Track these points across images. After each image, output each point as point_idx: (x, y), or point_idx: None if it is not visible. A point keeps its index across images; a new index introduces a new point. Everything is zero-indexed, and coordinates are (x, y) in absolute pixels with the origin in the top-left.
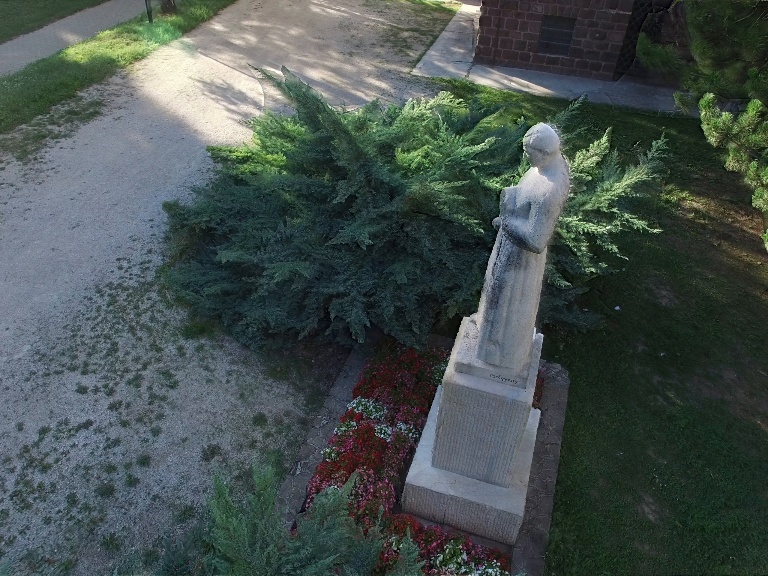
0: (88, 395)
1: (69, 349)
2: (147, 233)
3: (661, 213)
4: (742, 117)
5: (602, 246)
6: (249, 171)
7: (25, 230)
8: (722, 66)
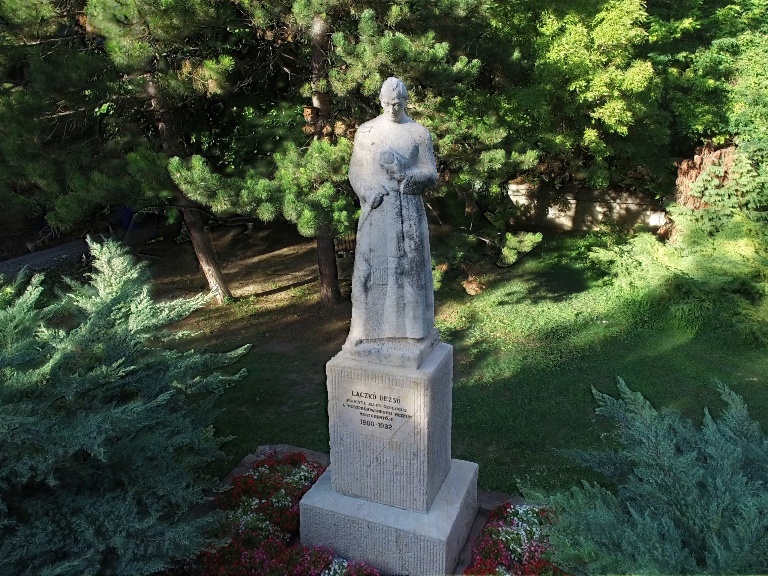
0: None
1: None
2: None
3: None
4: None
5: (174, 339)
6: None
7: None
8: (93, 166)
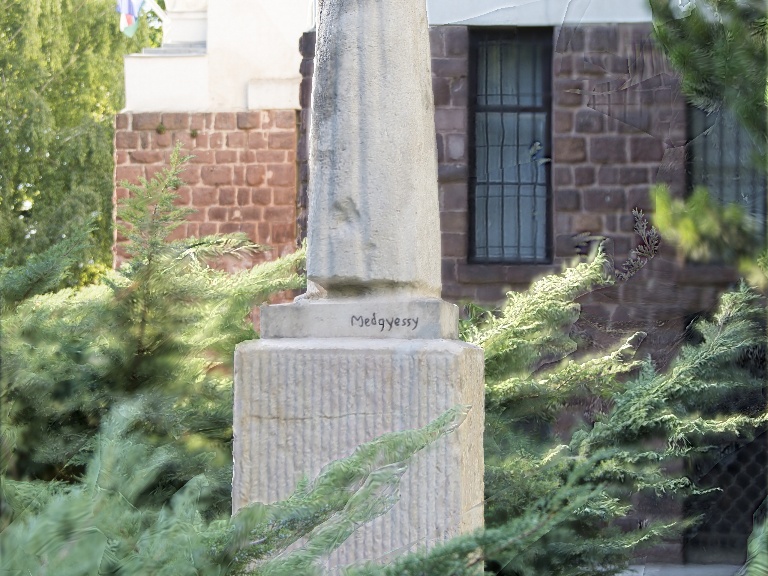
0: None
1: None
2: None
3: None
4: None
5: (650, 486)
6: None
7: None
8: None
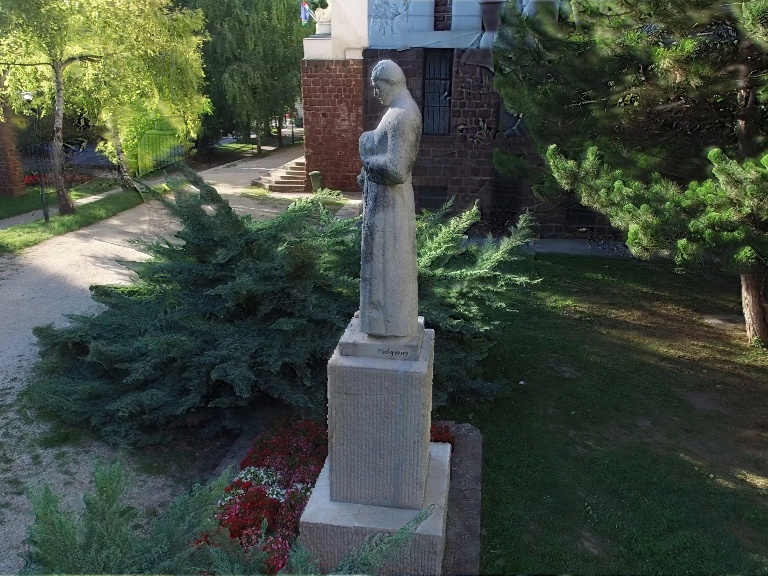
0: None
1: None
2: (13, 366)
3: (549, 316)
4: (585, 164)
5: (491, 305)
6: None
7: None
8: None
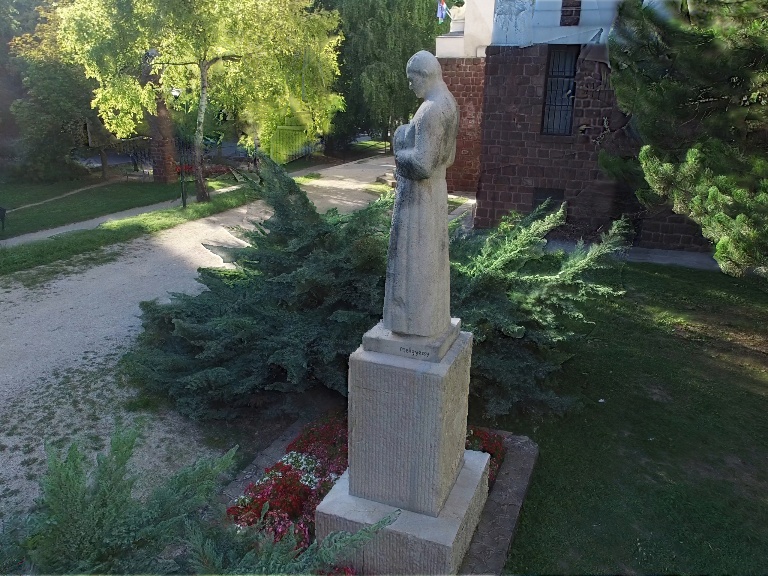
0: (4, 452)
1: (4, 416)
2: (123, 335)
3: (654, 333)
4: (684, 168)
5: (568, 315)
6: (233, 284)
7: (7, 331)
8: None
